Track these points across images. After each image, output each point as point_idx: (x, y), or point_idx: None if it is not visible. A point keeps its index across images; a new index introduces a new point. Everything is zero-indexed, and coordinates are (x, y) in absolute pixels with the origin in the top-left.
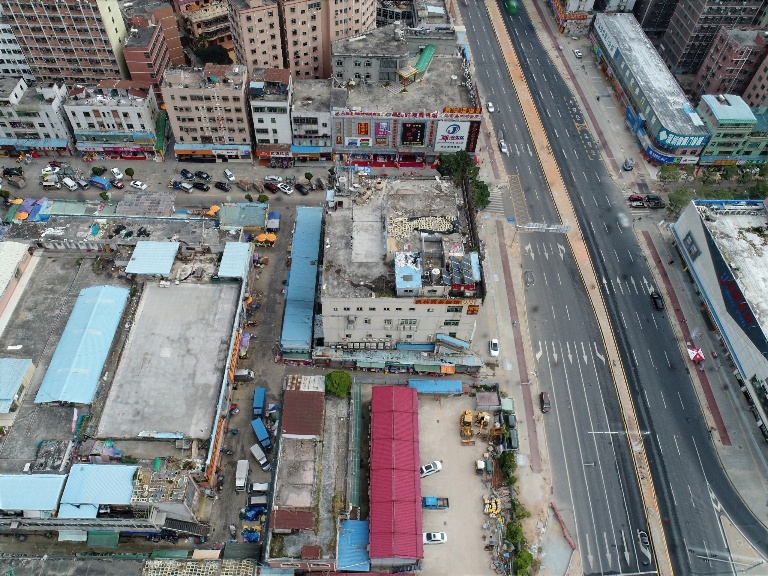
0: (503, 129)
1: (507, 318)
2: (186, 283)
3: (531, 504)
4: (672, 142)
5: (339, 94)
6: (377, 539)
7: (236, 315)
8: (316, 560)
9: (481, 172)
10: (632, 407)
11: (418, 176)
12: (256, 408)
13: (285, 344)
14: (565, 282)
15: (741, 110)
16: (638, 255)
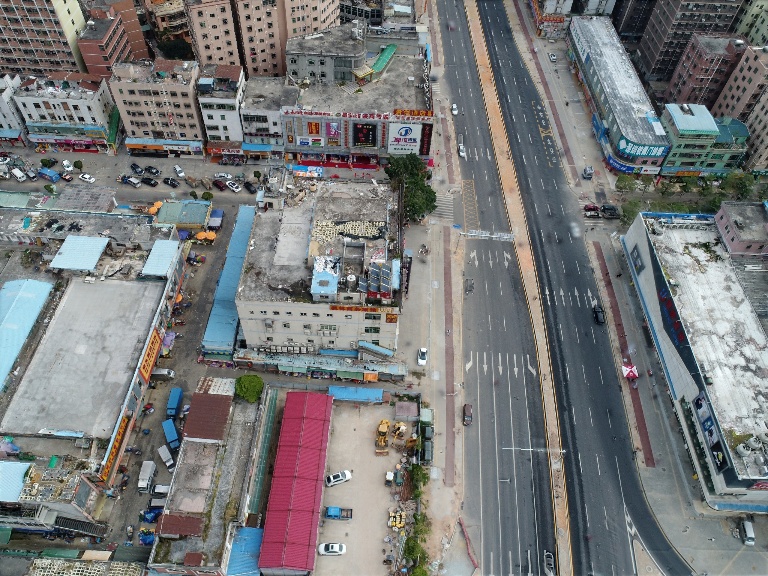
0: (465, 132)
1: (441, 326)
2: (112, 279)
3: (439, 519)
4: (632, 151)
5: (290, 92)
6: (268, 548)
7: (155, 314)
8: (199, 567)
9: (436, 176)
10: (557, 423)
11: None
12: (170, 409)
13: (206, 345)
14: (506, 292)
15: (704, 120)
16: (586, 266)
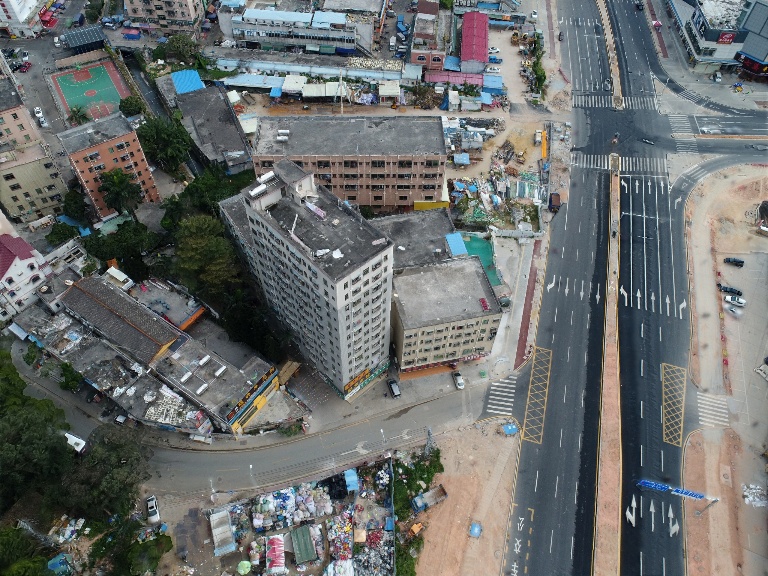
0: None
1: (544, 7)
2: None
3: (548, 68)
4: None
5: None
6: (465, 55)
7: None
8: (436, 50)
9: None
10: (613, 42)
11: None
12: (399, 22)
13: None
14: None
15: None
16: None
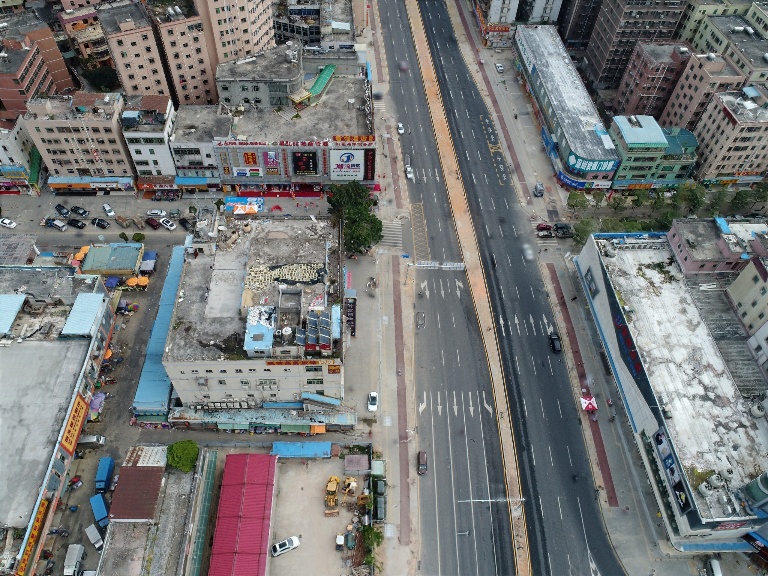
0: (412, 152)
1: (392, 366)
2: (30, 341)
3: None
4: (581, 167)
5: (223, 122)
6: None
7: (78, 378)
8: None
9: (383, 201)
10: (516, 465)
11: (292, 216)
12: (98, 481)
13: (138, 407)
14: (459, 323)
15: (652, 132)
16: (540, 291)
